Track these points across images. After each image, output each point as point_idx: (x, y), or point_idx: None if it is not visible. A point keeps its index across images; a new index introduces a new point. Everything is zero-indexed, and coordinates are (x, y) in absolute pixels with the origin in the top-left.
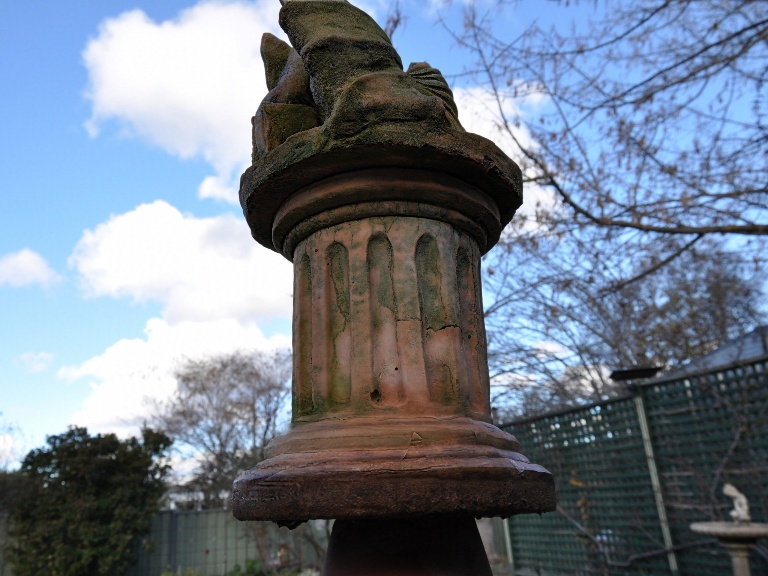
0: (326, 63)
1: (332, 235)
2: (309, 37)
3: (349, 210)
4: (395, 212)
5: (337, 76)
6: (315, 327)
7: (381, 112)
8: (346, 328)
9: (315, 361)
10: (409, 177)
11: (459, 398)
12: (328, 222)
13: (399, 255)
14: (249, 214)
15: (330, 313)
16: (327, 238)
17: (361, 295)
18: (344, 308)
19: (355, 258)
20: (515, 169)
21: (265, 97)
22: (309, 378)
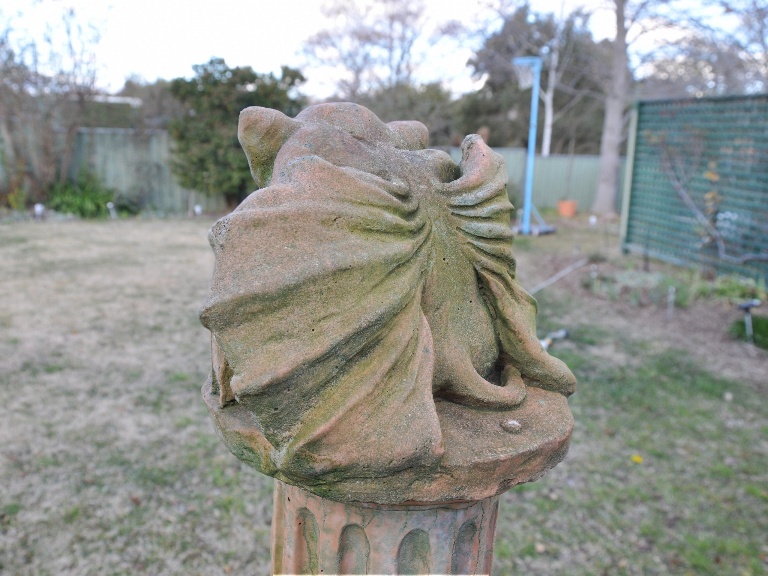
0: (265, 408)
1: (304, 499)
2: (239, 369)
3: None
4: (376, 509)
5: (282, 419)
6: None
7: (343, 472)
8: None
9: None
10: None
11: None
12: None
13: (376, 556)
14: None
15: (300, 575)
16: (299, 498)
17: None
18: (316, 573)
19: (325, 544)
20: (556, 449)
21: None
22: None
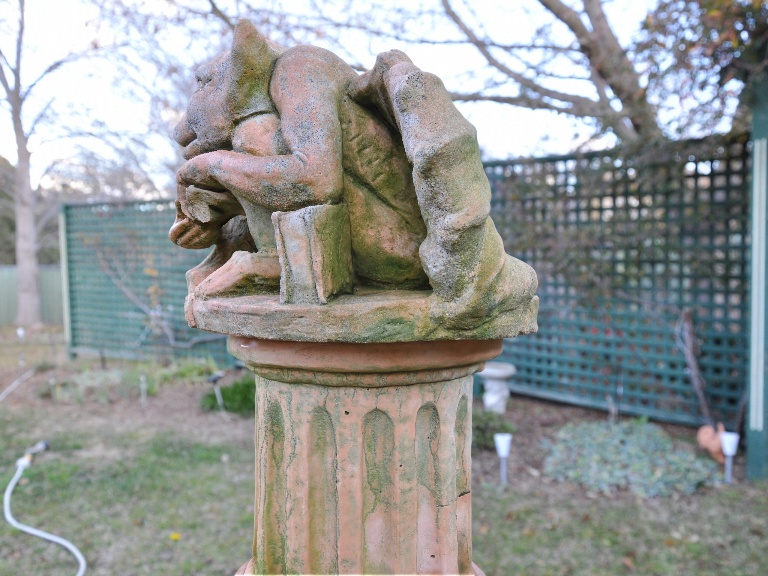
0: (472, 243)
1: (373, 400)
2: (462, 204)
3: (406, 379)
4: (447, 379)
5: (475, 257)
6: (345, 512)
7: (503, 305)
8: (377, 509)
9: (345, 554)
10: (477, 348)
11: (473, 567)
12: (373, 386)
13: (445, 429)
14: (236, 336)
15: (363, 494)
16: (366, 402)
17: (409, 482)
18: (375, 485)
19: (404, 436)
20: None
21: (280, 170)
22: (318, 558)
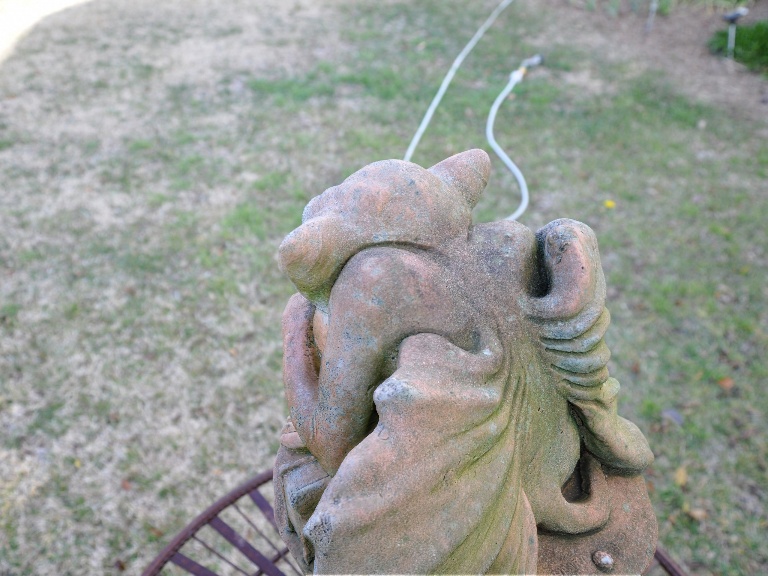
0: None
1: None
2: None
3: None
4: None
5: None
6: None
7: None
8: None
9: None
10: None
11: None
12: None
13: None
14: None
15: None
16: None
17: None
18: None
19: None
20: None
21: (296, 427)
22: None
